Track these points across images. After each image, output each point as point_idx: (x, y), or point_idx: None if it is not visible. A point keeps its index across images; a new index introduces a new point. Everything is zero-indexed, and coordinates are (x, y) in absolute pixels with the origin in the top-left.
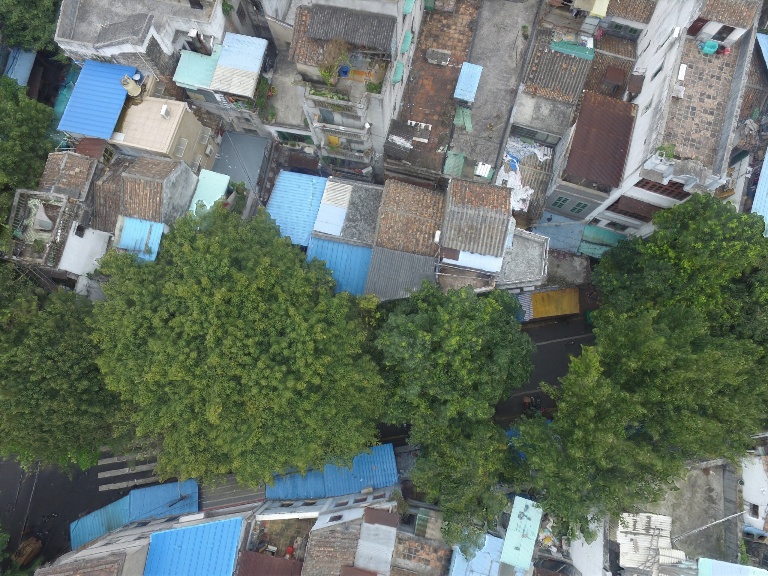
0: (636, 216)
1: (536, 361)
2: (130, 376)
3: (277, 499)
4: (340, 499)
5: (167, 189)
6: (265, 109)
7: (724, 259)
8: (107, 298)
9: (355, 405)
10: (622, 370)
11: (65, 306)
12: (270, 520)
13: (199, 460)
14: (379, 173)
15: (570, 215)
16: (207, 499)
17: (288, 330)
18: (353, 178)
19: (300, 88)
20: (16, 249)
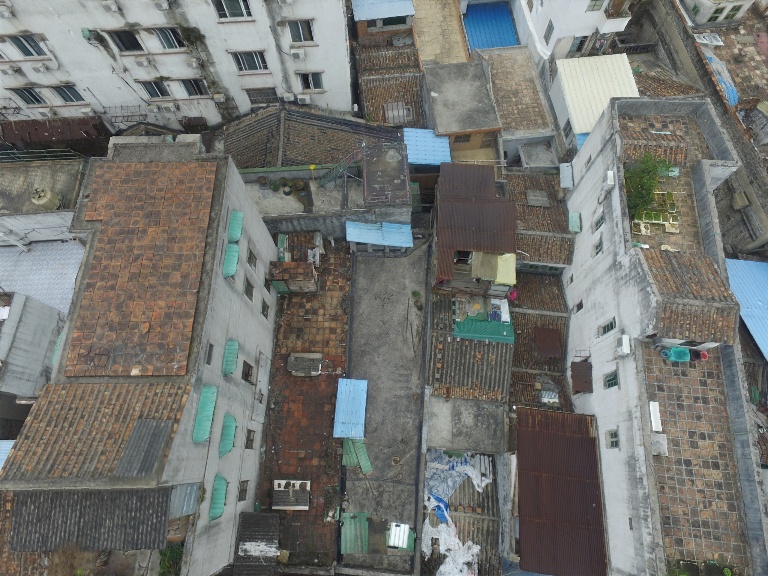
0: None
1: None
2: None
3: None
4: None
5: None
6: None
7: None
8: None
9: None
10: None
11: None
12: None
13: None
14: None
15: None
16: None
17: None
18: None
19: None
20: None
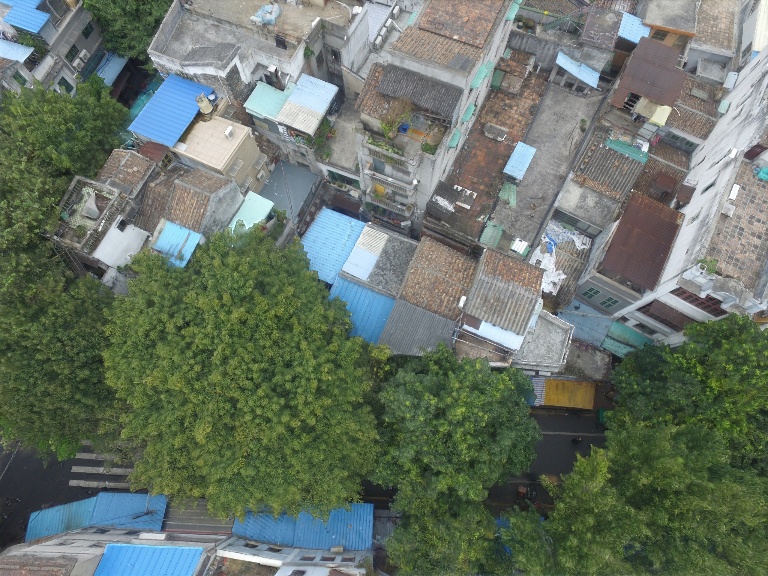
0: (667, 323)
1: (539, 450)
2: (131, 375)
3: (243, 537)
4: (307, 552)
5: (213, 203)
6: (322, 148)
7: (755, 387)
8: (130, 294)
9: (345, 455)
10: (630, 481)
11: (88, 293)
12: (230, 558)
13: (175, 477)
14: (417, 228)
15: (599, 308)
16: (172, 520)
17: (295, 363)
18: (390, 228)
19: (359, 135)
20: (59, 230)
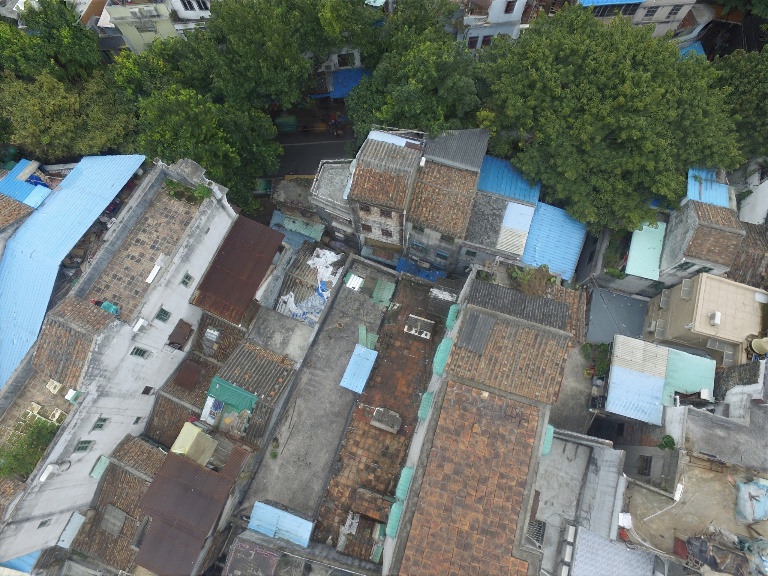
0: None
1: None
2: None
3: None
4: None
5: None
6: None
7: None
8: None
9: None
10: None
11: (764, 134)
12: None
13: None
14: None
15: None
16: None
17: None
18: None
19: None
20: None
